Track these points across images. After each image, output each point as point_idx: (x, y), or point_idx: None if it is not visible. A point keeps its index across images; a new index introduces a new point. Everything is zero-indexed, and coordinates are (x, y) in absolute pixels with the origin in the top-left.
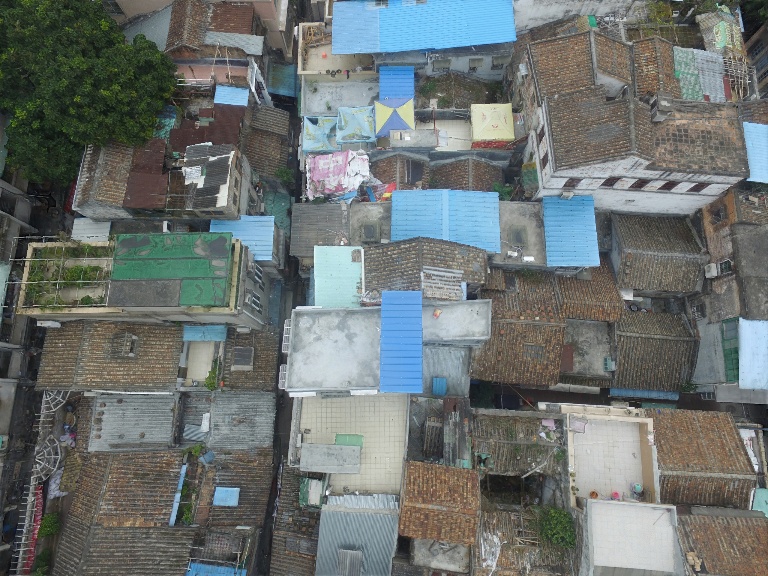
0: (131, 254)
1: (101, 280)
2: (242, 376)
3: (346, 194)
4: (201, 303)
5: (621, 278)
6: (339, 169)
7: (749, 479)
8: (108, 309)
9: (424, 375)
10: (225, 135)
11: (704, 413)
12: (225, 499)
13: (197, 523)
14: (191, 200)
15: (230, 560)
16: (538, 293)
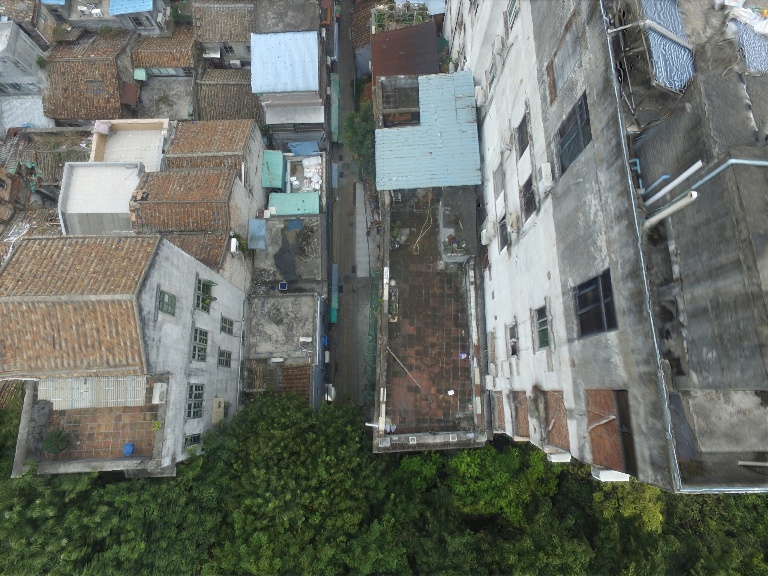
0: None
1: None
2: None
3: None
4: None
5: (195, 31)
6: None
7: (237, 154)
8: None
9: (16, 125)
10: None
11: (231, 121)
12: None
13: None
14: None
15: None
16: (110, 43)
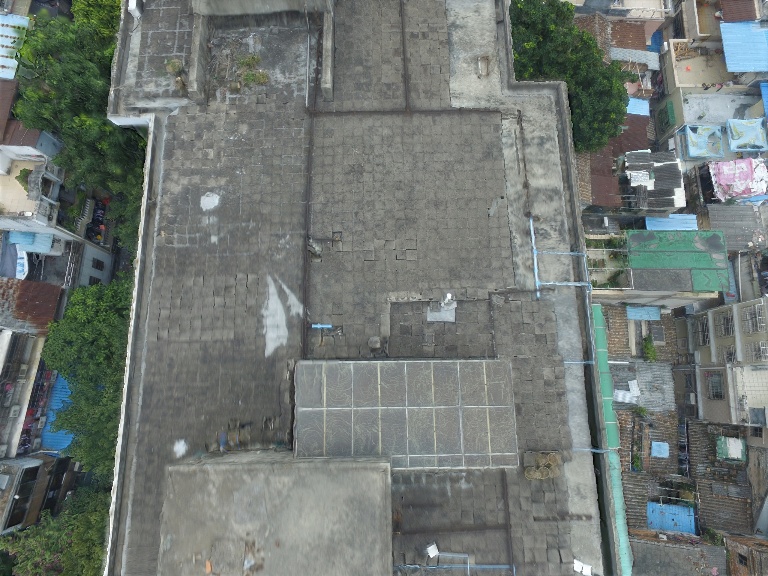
0: (642, 247)
1: (623, 268)
2: (658, 350)
3: (753, 197)
4: (711, 289)
5: None
6: (746, 175)
7: None
8: (613, 292)
9: None
10: (638, 142)
11: None
12: (660, 451)
13: (644, 470)
14: (645, 200)
15: (654, 501)
16: None
